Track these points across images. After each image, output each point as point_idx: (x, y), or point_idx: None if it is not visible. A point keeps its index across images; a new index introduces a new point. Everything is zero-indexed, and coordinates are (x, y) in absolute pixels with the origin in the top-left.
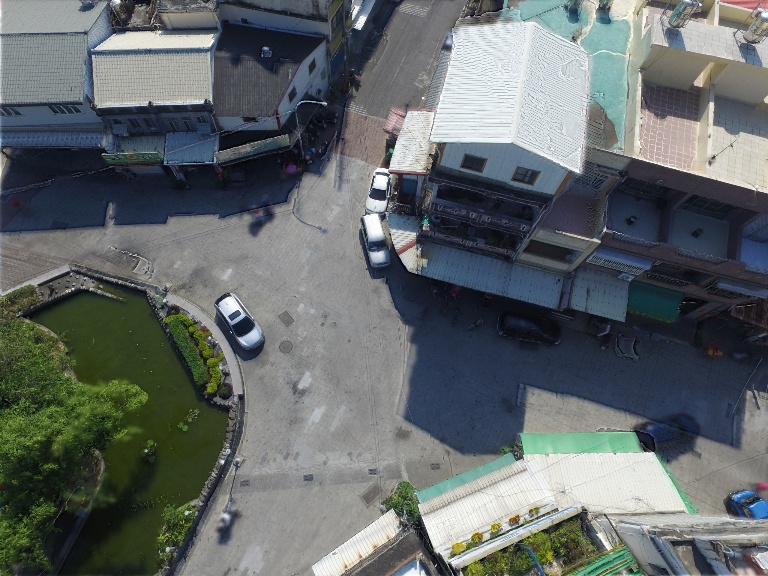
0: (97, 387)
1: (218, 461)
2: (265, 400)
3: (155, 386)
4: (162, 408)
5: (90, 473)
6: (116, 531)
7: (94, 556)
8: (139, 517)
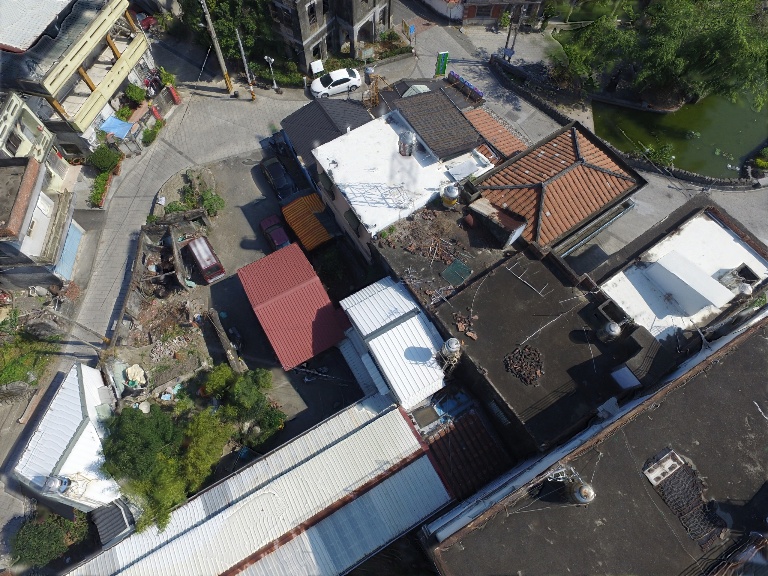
0: (720, 98)
1: (705, 176)
2: (760, 203)
3: (737, 131)
4: (724, 138)
5: (667, 105)
6: (636, 127)
7: (617, 119)
8: (648, 137)
